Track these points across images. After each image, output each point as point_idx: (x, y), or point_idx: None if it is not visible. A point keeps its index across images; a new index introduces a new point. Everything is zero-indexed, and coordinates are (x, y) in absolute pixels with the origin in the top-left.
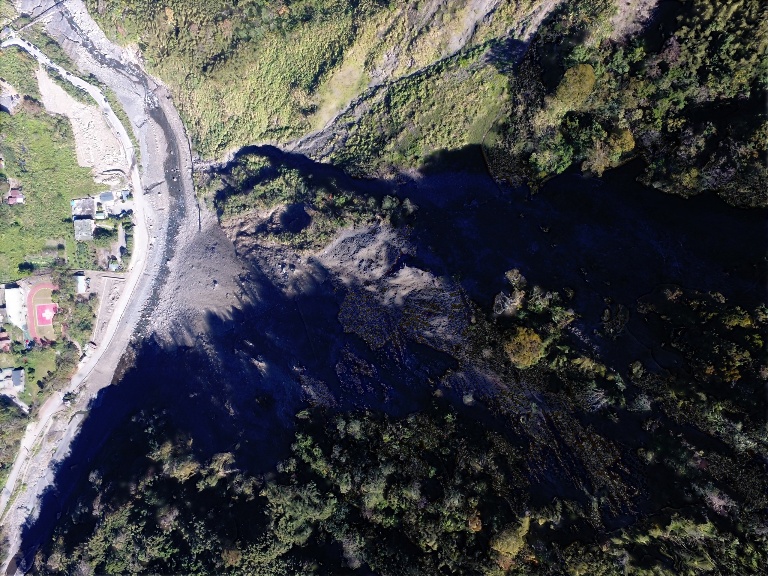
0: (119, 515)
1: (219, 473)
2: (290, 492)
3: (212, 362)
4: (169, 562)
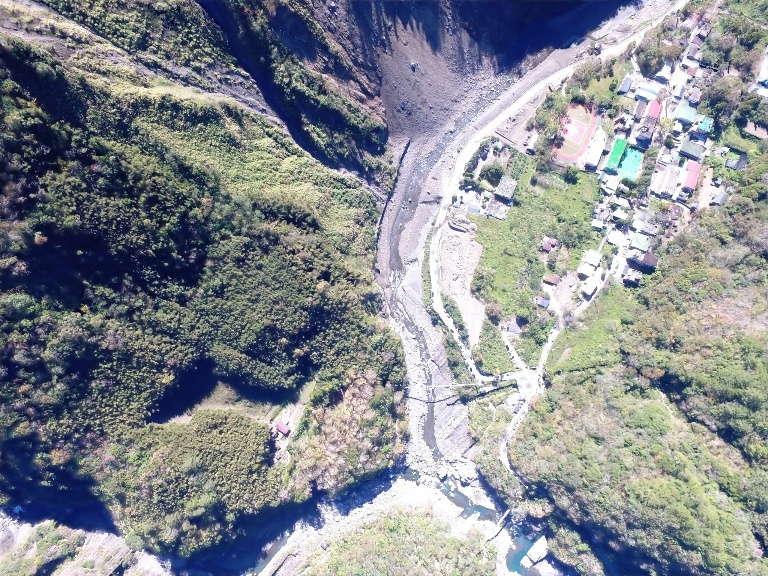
0: None
1: None
2: None
3: None
4: None
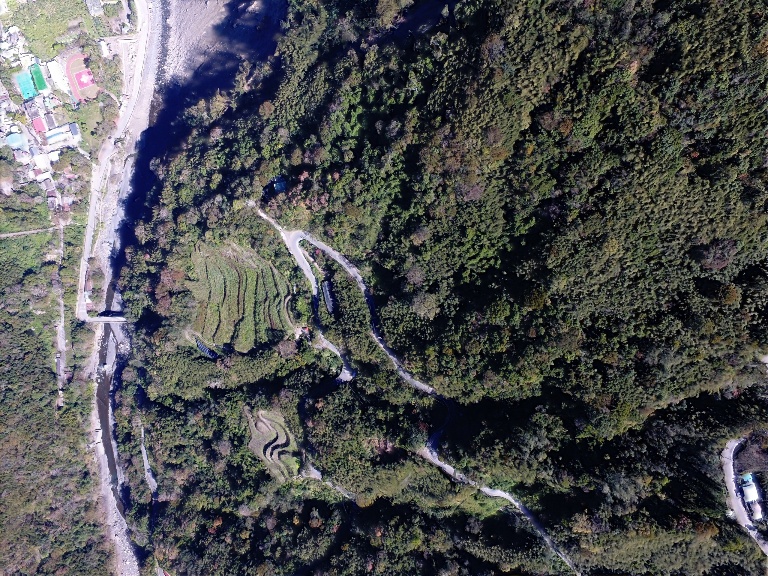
0: (179, 160)
1: (244, 87)
2: (294, 30)
3: (220, 51)
4: (225, 164)
